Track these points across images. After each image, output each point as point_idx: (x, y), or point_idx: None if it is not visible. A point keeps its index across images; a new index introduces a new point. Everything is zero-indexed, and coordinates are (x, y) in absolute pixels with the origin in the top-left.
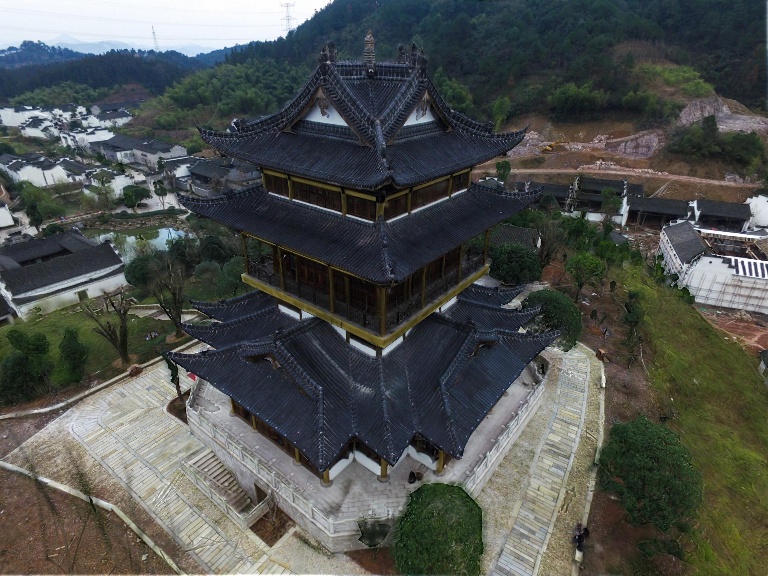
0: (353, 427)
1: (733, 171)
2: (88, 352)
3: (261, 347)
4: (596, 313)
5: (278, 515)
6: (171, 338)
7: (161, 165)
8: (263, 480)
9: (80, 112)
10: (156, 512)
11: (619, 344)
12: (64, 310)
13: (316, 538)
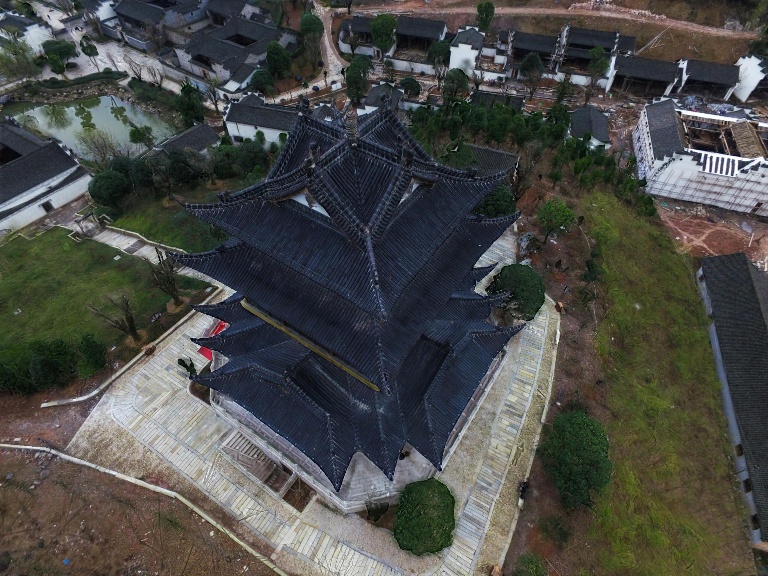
0: (356, 440)
1: (735, 15)
2: (105, 347)
3: (272, 375)
4: (560, 263)
5: (302, 487)
6: (171, 307)
7: (78, 4)
8: (287, 465)
9: None
10: (208, 490)
11: (576, 293)
12: (33, 224)
13: (333, 504)
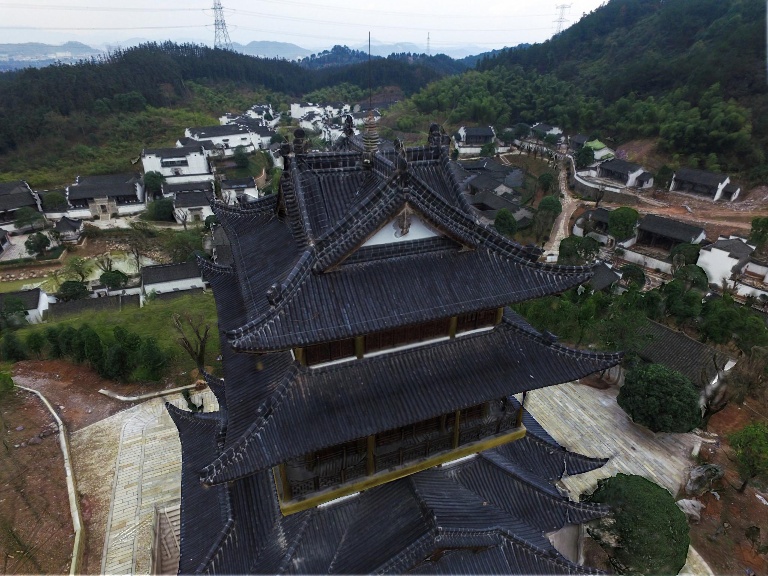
0: None
1: None
2: (164, 360)
3: None
4: (758, 532)
5: None
6: None
7: None
8: None
9: (345, 109)
10: (109, 550)
11: None
12: None
13: None
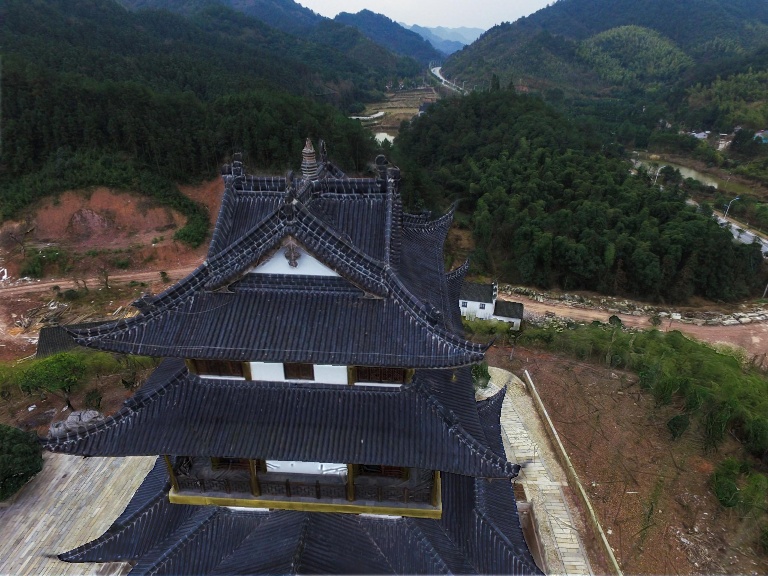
0: None
1: None
2: None
3: None
4: None
5: None
6: None
7: None
8: None
9: None
10: None
11: None
12: None
13: None
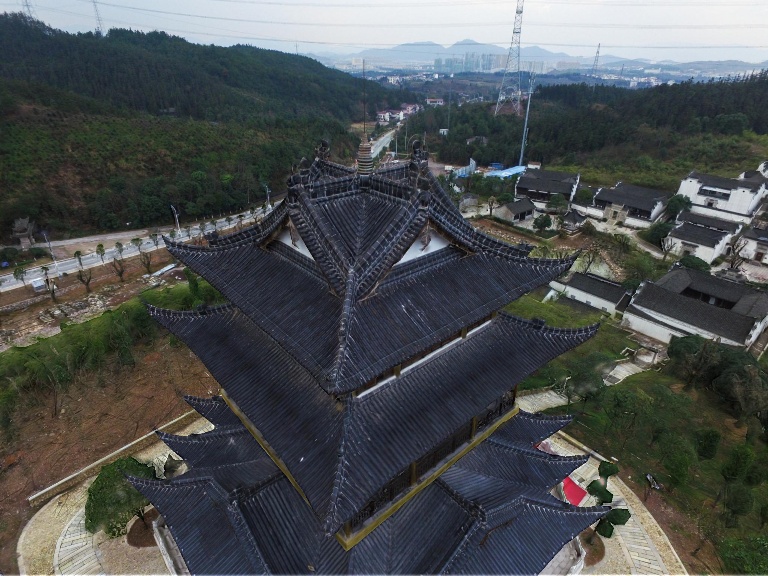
0: (224, 426)
1: None
2: None
3: None
4: None
5: None
6: None
7: None
8: None
9: None
10: None
11: None
12: (652, 339)
13: None
